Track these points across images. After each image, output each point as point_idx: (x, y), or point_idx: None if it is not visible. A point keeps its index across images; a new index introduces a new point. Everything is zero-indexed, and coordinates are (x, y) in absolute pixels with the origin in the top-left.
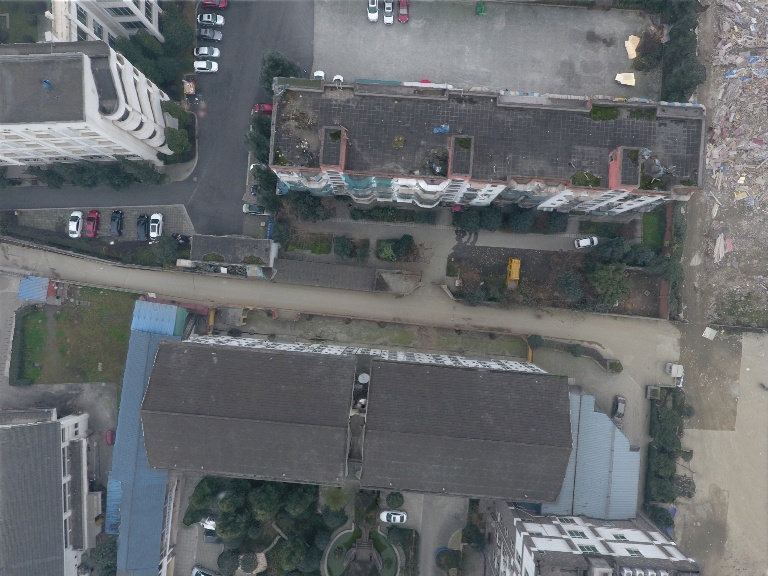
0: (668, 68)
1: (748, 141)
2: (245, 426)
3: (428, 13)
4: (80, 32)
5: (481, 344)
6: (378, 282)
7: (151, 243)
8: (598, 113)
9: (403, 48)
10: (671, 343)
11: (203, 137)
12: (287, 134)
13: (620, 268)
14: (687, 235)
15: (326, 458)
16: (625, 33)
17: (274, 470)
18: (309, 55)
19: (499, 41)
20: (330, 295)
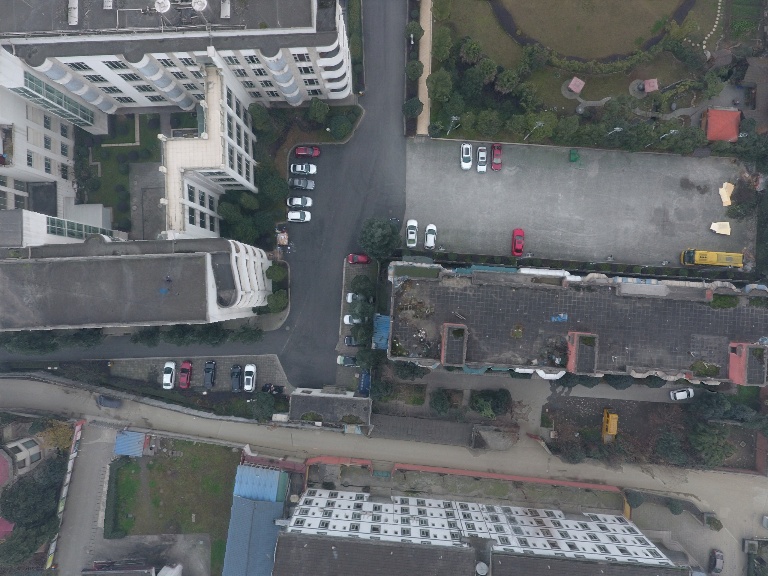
0: (764, 217)
1: None
2: None
3: (521, 160)
4: (190, 211)
5: (576, 496)
6: (476, 439)
7: (249, 401)
8: (717, 302)
9: (496, 196)
10: (767, 495)
11: (295, 286)
12: (404, 323)
13: (724, 432)
14: None
15: None
16: (719, 180)
17: None
18: (401, 203)
19: (592, 188)
20: (424, 446)
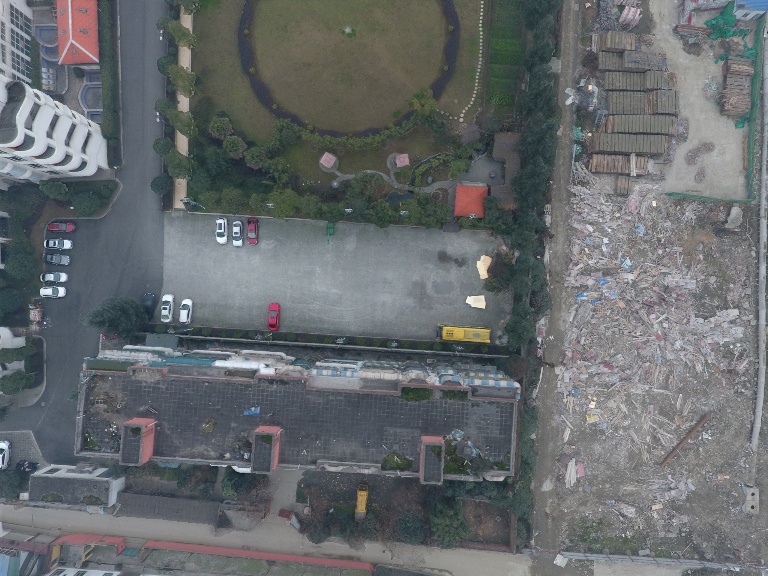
0: None
1: (598, 366)
2: None
3: (279, 234)
4: None
5: (330, 573)
6: (220, 519)
7: None
8: (410, 394)
9: (253, 269)
10: (522, 571)
11: (51, 361)
12: (96, 417)
13: (458, 514)
14: (538, 459)
15: None
16: (477, 253)
17: None
18: (159, 277)
19: (350, 262)
20: (178, 523)
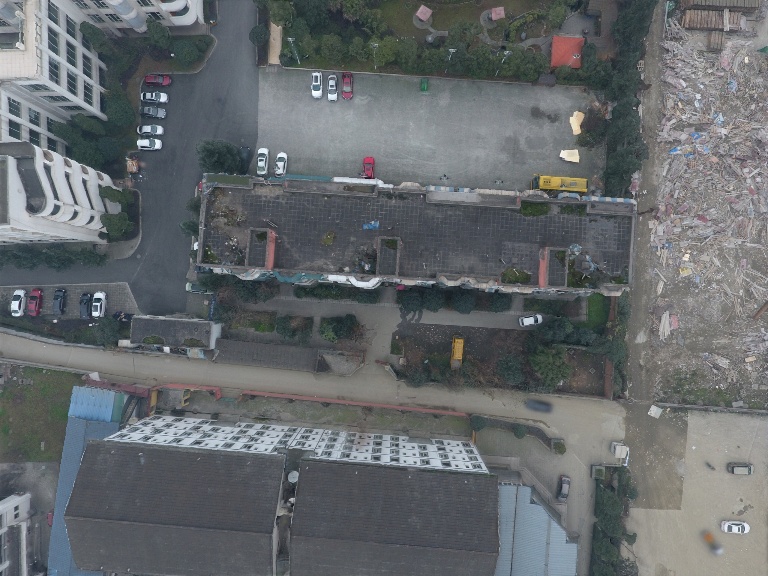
0: (612, 145)
1: (692, 218)
2: (169, 531)
3: (373, 89)
4: (13, 124)
5: (425, 423)
6: (320, 363)
7: (91, 325)
8: (528, 209)
9: (347, 124)
10: (616, 421)
11: (147, 214)
12: (216, 231)
13: (560, 352)
14: (632, 312)
15: (252, 561)
16: (570, 109)
17: (201, 572)
18: (253, 132)
19: (444, 117)
20: (274, 373)
